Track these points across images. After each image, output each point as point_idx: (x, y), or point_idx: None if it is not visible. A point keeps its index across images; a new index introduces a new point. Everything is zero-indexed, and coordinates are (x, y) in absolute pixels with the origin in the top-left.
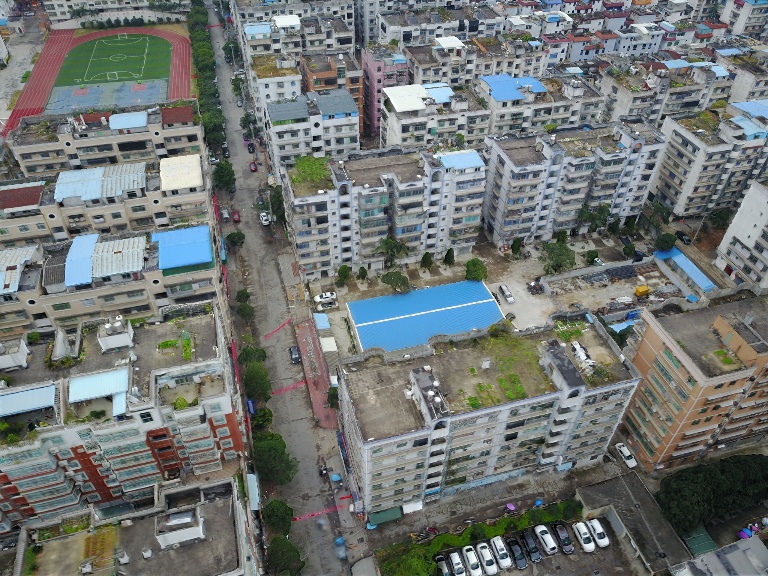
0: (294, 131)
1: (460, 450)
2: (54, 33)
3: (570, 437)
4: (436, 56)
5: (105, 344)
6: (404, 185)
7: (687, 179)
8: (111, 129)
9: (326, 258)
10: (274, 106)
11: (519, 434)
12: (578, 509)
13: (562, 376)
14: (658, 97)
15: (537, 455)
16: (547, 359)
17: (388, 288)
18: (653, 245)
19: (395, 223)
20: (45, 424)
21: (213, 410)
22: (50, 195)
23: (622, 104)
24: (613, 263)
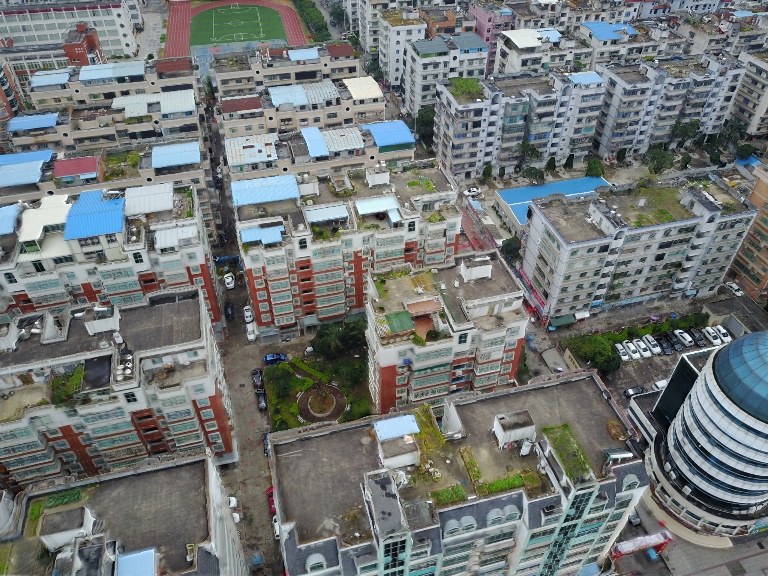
0: (436, 63)
1: (623, 266)
2: (173, 4)
3: (700, 263)
4: (534, 10)
5: (373, 180)
6: (542, 96)
7: (760, 102)
8: (291, 60)
9: (473, 160)
10: (419, 43)
11: (665, 256)
12: (705, 319)
13: (703, 206)
14: (729, 40)
15: (673, 280)
16: (688, 198)
17: (520, 186)
18: (732, 156)
19: (529, 131)
20: (344, 229)
21: (450, 229)
22: (268, 102)
23: (699, 46)
24: (702, 168)
